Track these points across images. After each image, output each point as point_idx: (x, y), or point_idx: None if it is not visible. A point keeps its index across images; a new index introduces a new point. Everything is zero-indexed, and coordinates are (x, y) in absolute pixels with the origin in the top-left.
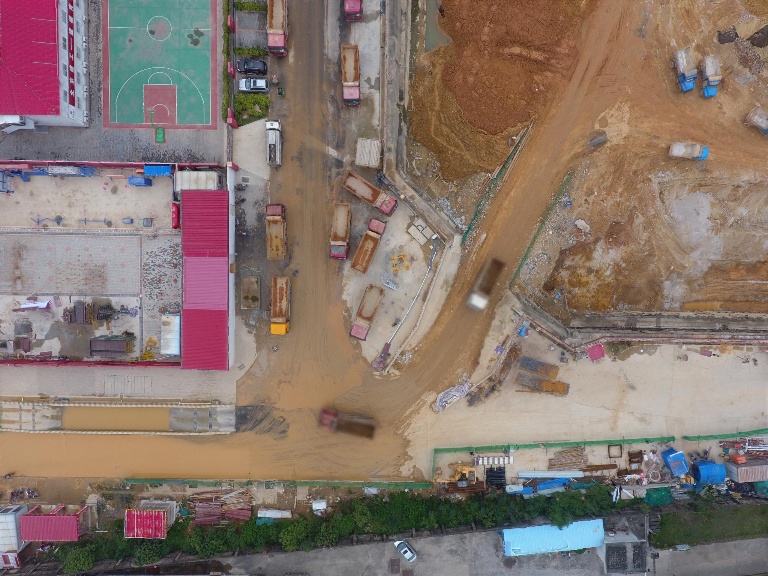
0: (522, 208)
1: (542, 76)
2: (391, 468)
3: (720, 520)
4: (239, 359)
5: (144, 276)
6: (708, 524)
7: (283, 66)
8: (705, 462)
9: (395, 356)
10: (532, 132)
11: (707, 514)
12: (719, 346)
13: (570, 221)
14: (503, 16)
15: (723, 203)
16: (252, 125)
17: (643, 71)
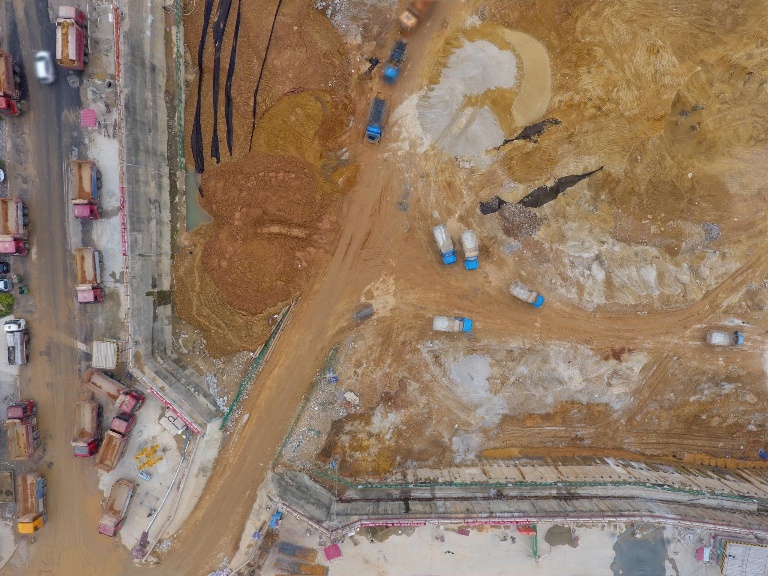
0: (285, 386)
1: (305, 252)
2: None
3: None
4: None
5: None
6: None
7: (26, 263)
8: None
9: (151, 546)
10: (295, 309)
11: None
12: (477, 525)
13: (340, 393)
14: (255, 200)
15: (502, 363)
16: None
17: (407, 243)
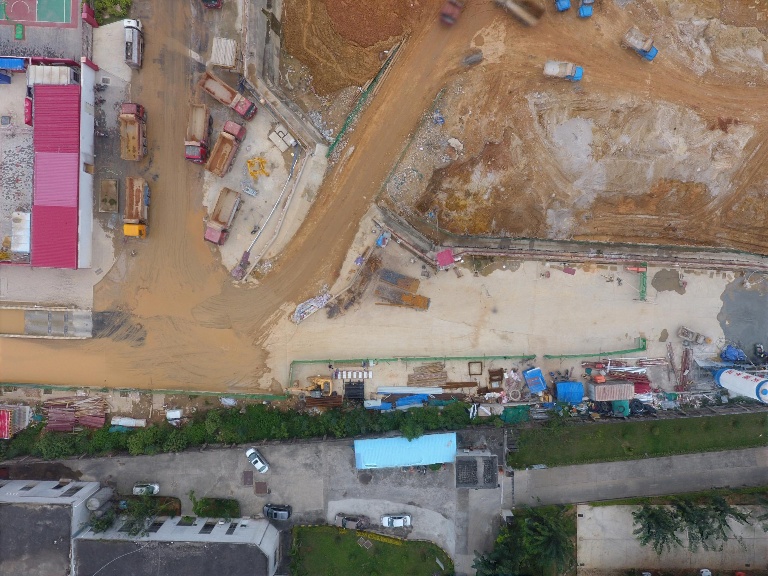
0: (392, 123)
1: None
2: (249, 380)
3: (580, 442)
4: (96, 263)
5: (1, 175)
6: (568, 445)
7: None
8: (566, 382)
9: (253, 264)
10: (405, 47)
11: (560, 430)
12: (583, 264)
13: (444, 139)
14: None
15: (605, 130)
16: (113, 25)
17: None
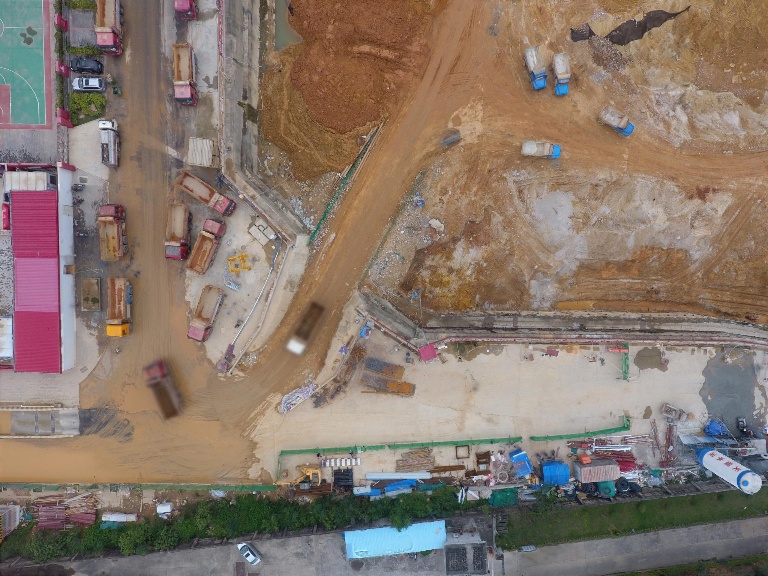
0: (372, 207)
1: (393, 74)
2: (238, 470)
3: (568, 520)
4: (81, 361)
5: None
6: (556, 525)
7: (120, 65)
8: (552, 462)
9: (238, 357)
10: (383, 131)
11: None
12: (566, 346)
13: (425, 220)
14: (348, 14)
15: (584, 202)
16: (89, 125)
17: (496, 69)
